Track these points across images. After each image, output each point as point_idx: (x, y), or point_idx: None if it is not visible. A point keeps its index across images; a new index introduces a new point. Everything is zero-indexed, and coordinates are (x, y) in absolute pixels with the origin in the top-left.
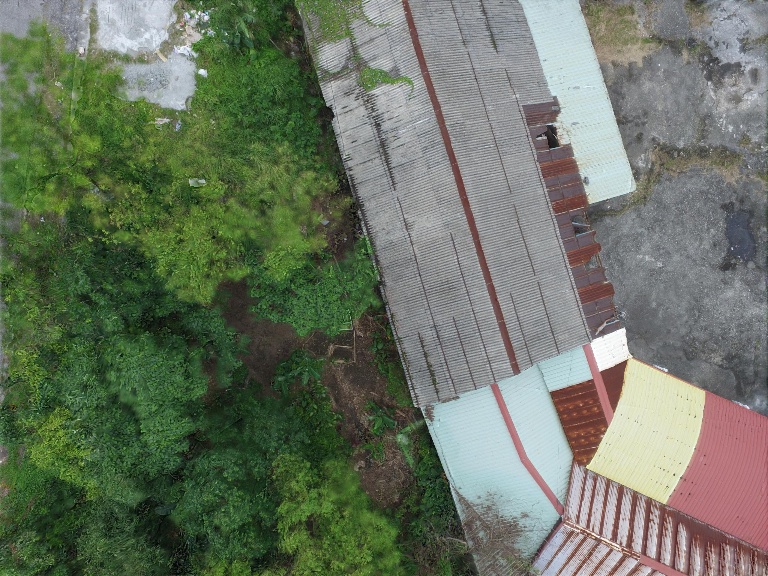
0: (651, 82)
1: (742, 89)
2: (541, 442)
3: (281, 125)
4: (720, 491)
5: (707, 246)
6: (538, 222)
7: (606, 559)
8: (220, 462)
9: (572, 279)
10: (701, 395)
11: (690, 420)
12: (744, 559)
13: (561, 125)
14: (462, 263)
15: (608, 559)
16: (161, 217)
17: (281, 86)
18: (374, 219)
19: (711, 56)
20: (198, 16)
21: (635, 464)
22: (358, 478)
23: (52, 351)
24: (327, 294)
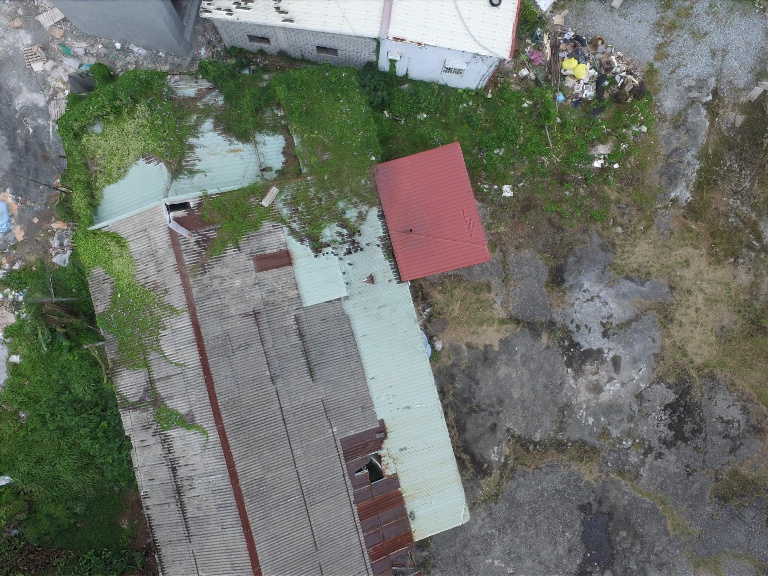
0: (507, 367)
1: (604, 378)
2: None
3: (93, 426)
4: None
5: (561, 551)
6: None
7: None
8: None
9: None
10: None
11: None
12: None
13: (387, 452)
14: None
15: None
16: None
17: (91, 388)
18: (170, 567)
19: (572, 341)
20: (12, 296)
21: None
22: None
23: None
24: None
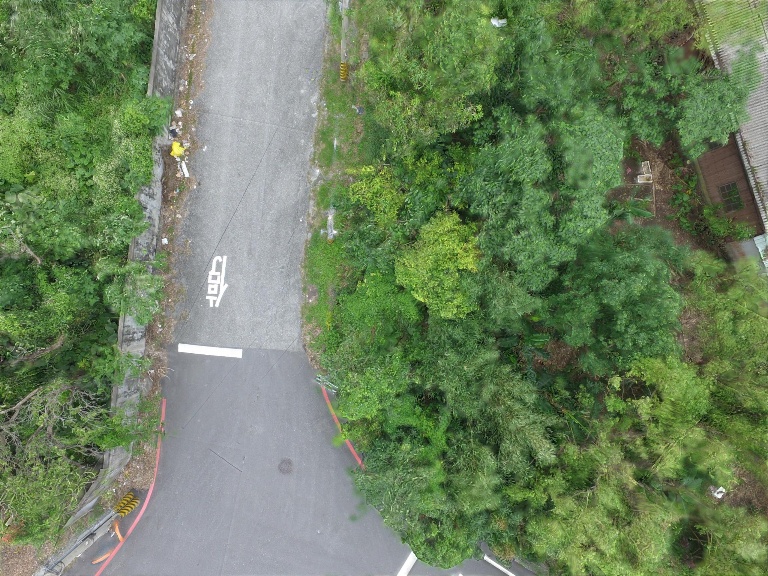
0: None
1: None
2: None
3: None
4: None
5: None
6: None
7: None
8: (635, 260)
9: None
10: None
11: None
12: None
13: None
14: None
15: None
16: (469, 53)
17: None
18: (726, 41)
19: None
20: None
21: None
22: None
23: (406, 165)
24: (719, 98)
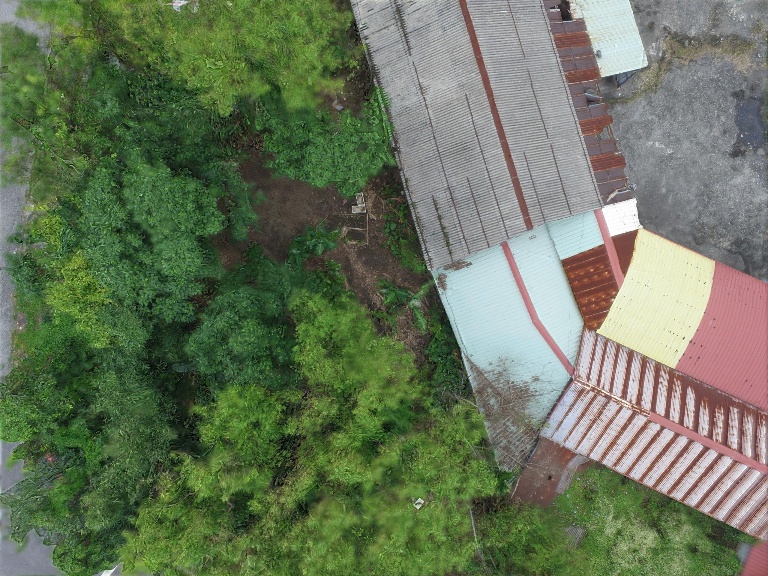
0: None
1: None
2: (552, 306)
3: (297, 5)
4: (729, 354)
5: (717, 133)
6: (551, 89)
7: (616, 418)
8: (239, 295)
9: (584, 146)
10: (711, 264)
11: (700, 286)
12: (752, 421)
13: None
14: (476, 122)
15: (618, 418)
16: (179, 94)
17: None
18: (389, 86)
19: None
20: None
21: (645, 328)
22: (370, 357)
23: (74, 204)
24: (344, 143)
